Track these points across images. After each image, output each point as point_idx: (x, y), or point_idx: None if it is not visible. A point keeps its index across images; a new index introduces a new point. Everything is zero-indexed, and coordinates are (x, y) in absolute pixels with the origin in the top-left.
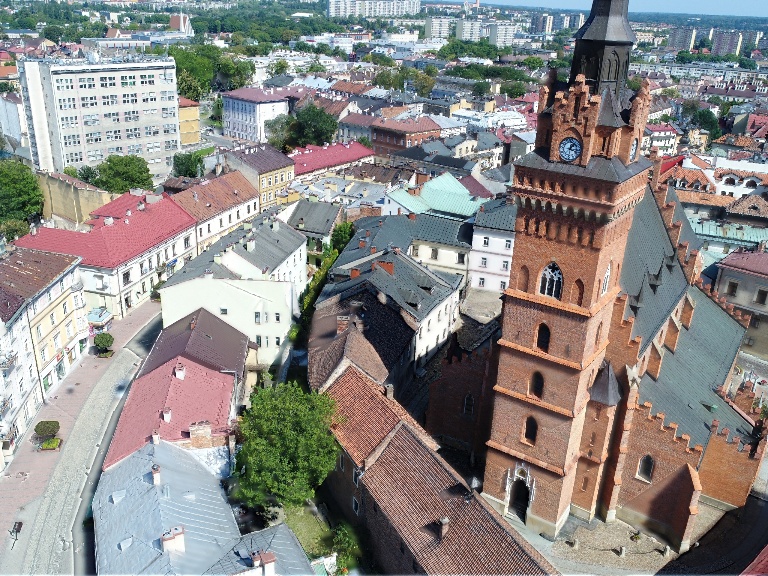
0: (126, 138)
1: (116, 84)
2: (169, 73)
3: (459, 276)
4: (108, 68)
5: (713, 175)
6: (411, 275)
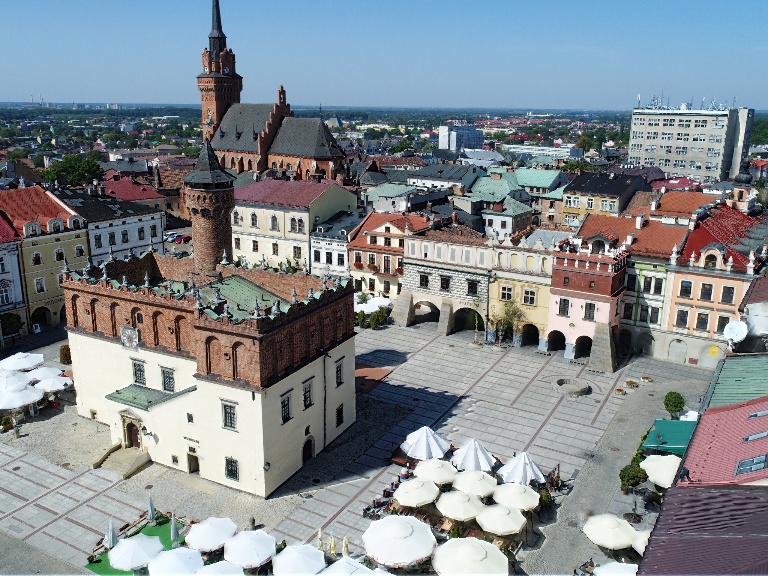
0: (673, 167)
1: (675, 125)
2: (722, 120)
3: None
4: (672, 113)
5: (652, 210)
6: None
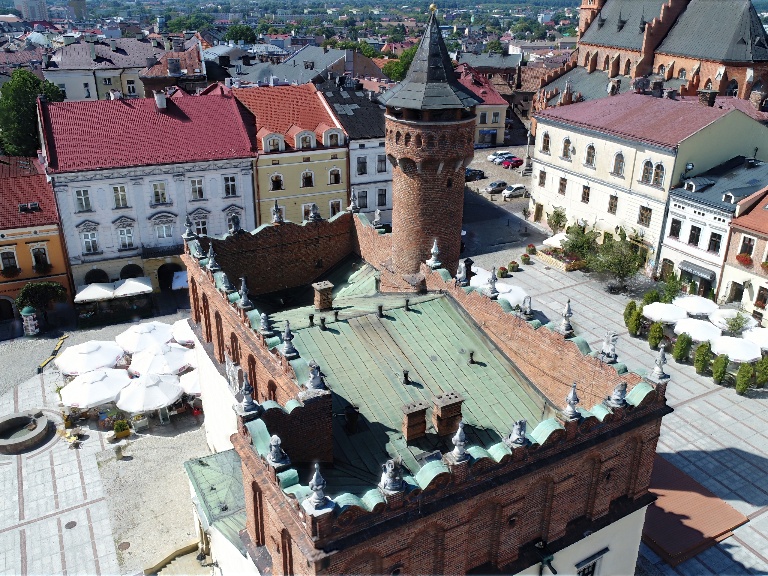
0: None
1: None
2: None
3: None
4: None
5: None
6: None
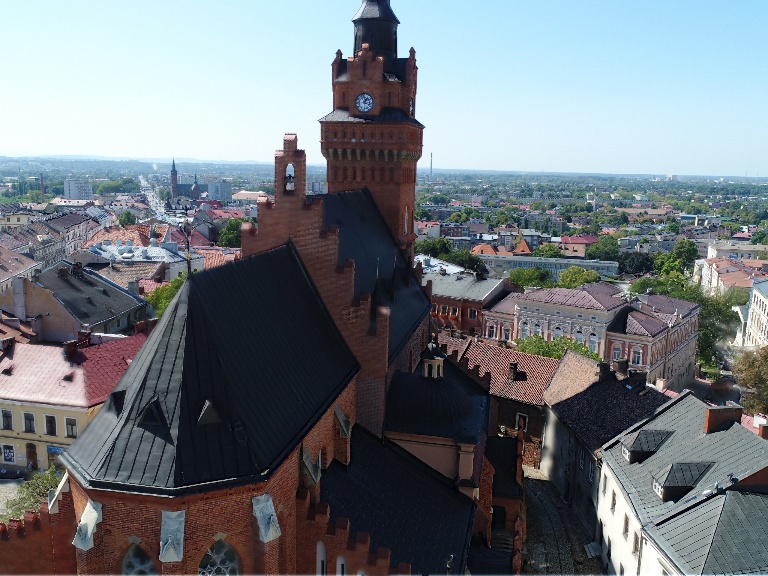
0: None
1: None
2: None
3: (696, 573)
4: None
5: None
6: (706, 463)
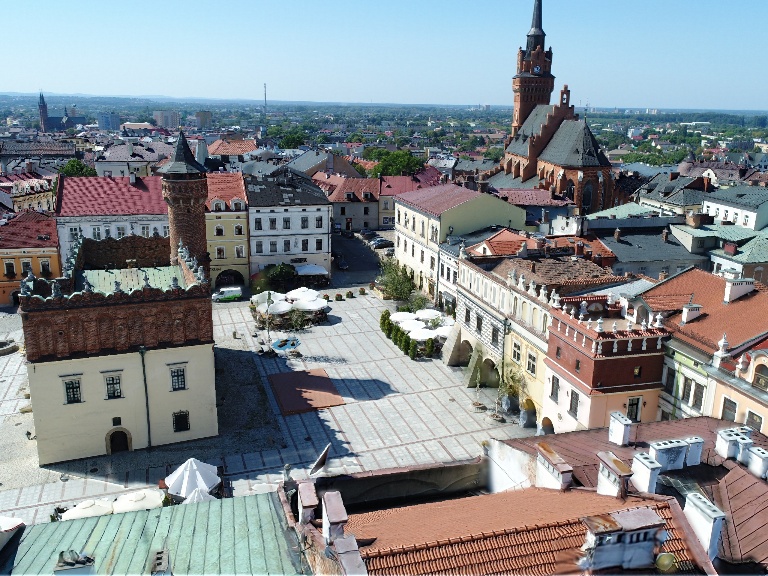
0: None
1: None
2: None
3: None
4: None
5: None
6: None
